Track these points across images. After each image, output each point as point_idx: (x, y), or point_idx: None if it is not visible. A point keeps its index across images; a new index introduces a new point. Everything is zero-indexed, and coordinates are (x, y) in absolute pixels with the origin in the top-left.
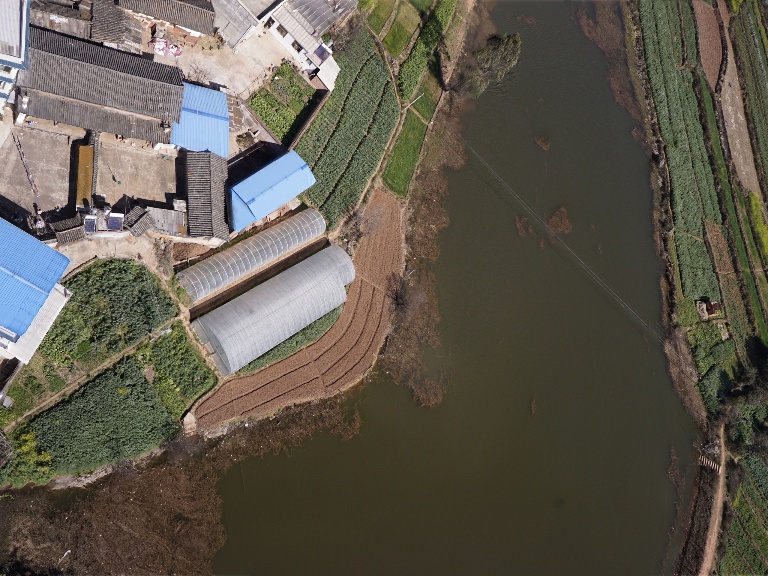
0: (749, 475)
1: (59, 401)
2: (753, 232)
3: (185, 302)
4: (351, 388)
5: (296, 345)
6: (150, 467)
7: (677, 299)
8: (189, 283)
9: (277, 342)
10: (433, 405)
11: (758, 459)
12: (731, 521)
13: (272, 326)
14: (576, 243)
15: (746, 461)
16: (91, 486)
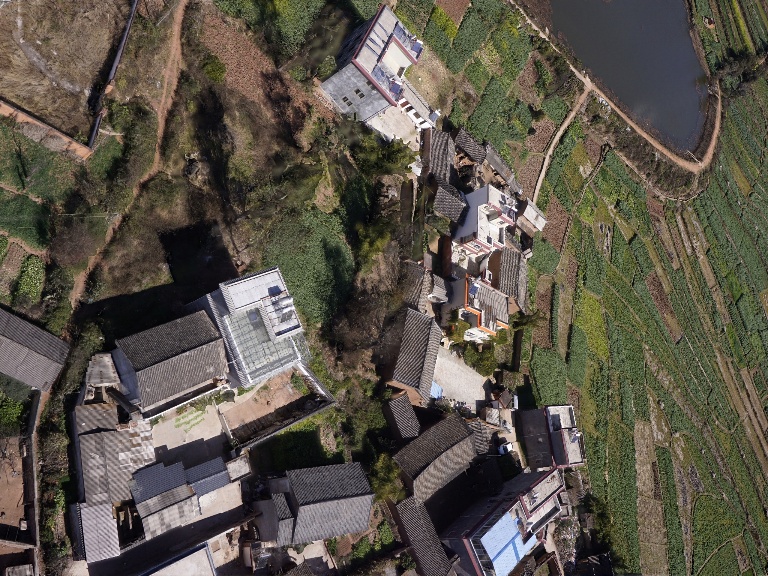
0: (730, 111)
1: None
2: None
3: None
4: None
5: None
6: None
7: (694, 12)
8: None
9: None
10: (607, 3)
11: (734, 105)
12: None
13: None
14: None
15: None
16: None
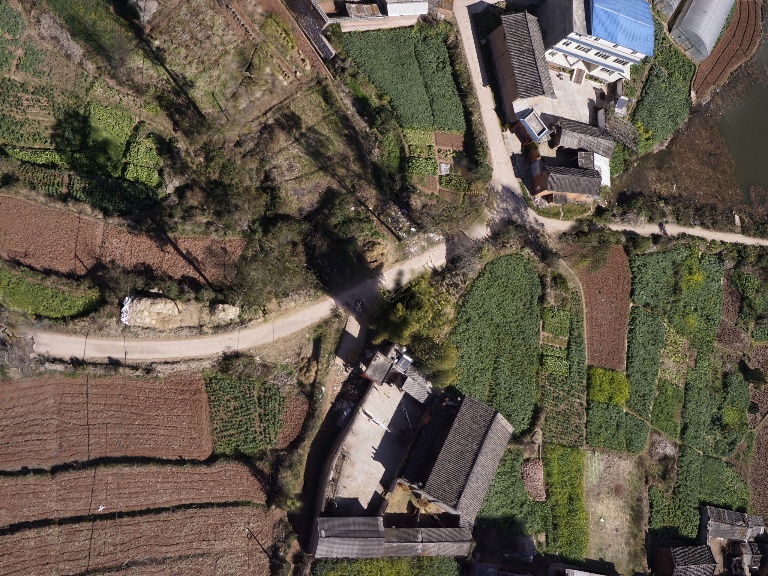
0: None
1: (637, 102)
2: None
3: (664, 19)
4: (756, 50)
5: None
6: (686, 129)
7: None
8: (668, 4)
9: (720, 29)
10: None
11: None
12: None
13: (718, 18)
14: None
15: None
16: (667, 147)
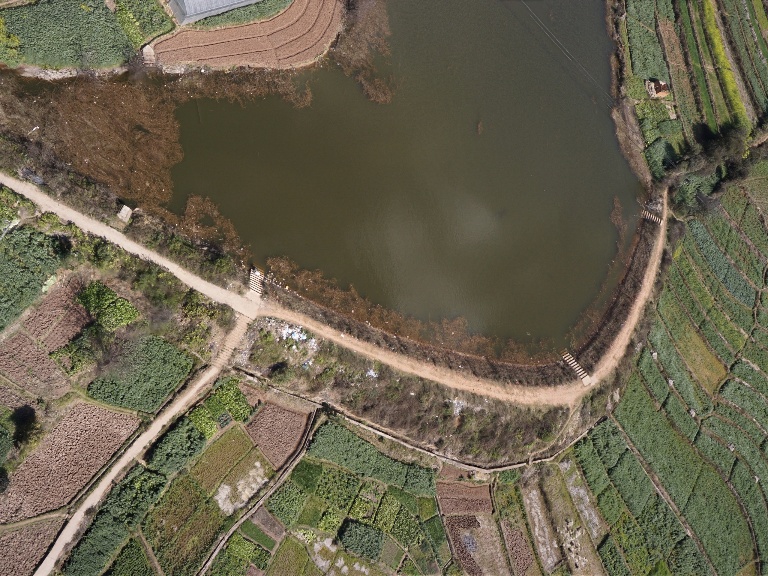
0: (691, 238)
1: (26, 4)
2: (705, 33)
3: None
4: (303, 68)
5: (250, 14)
6: (112, 81)
7: (626, 75)
8: None
9: (231, 2)
10: (382, 102)
11: (700, 226)
12: (669, 263)
13: None
14: None
15: (688, 225)
16: (57, 82)
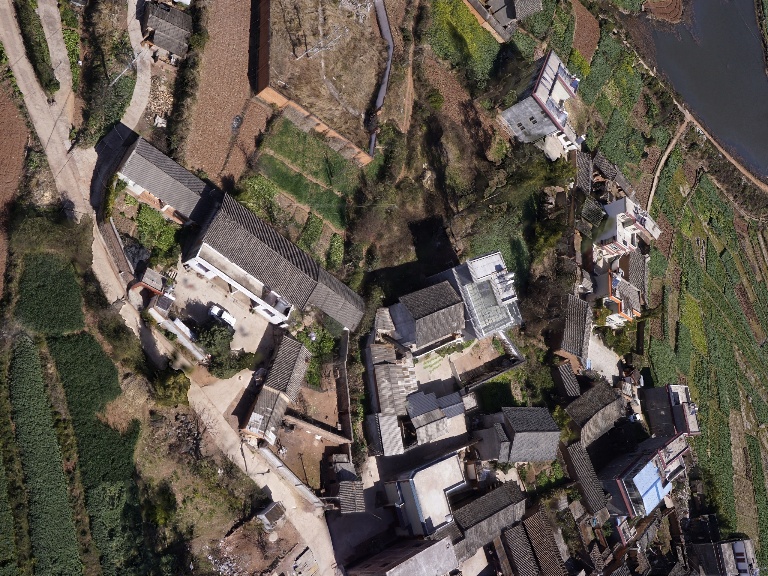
0: None
1: None
2: None
3: None
4: (676, 24)
5: None
6: None
7: None
8: None
9: None
10: (698, 44)
11: None
12: None
13: None
14: (731, 8)
15: None
16: (626, 15)
